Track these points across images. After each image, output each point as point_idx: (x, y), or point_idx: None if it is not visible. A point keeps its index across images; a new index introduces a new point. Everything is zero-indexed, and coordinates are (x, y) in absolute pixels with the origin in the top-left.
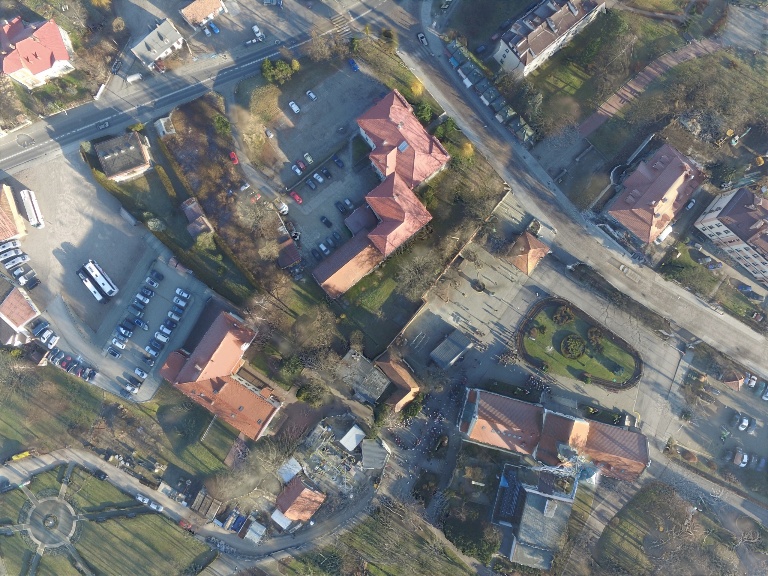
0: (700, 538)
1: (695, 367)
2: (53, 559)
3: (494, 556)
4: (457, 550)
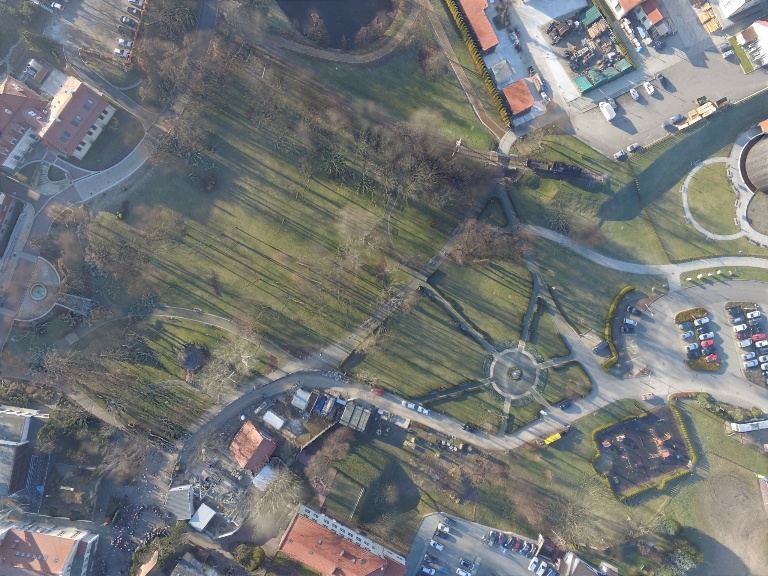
0: None
1: None
2: (508, 338)
3: (54, 406)
4: (93, 407)
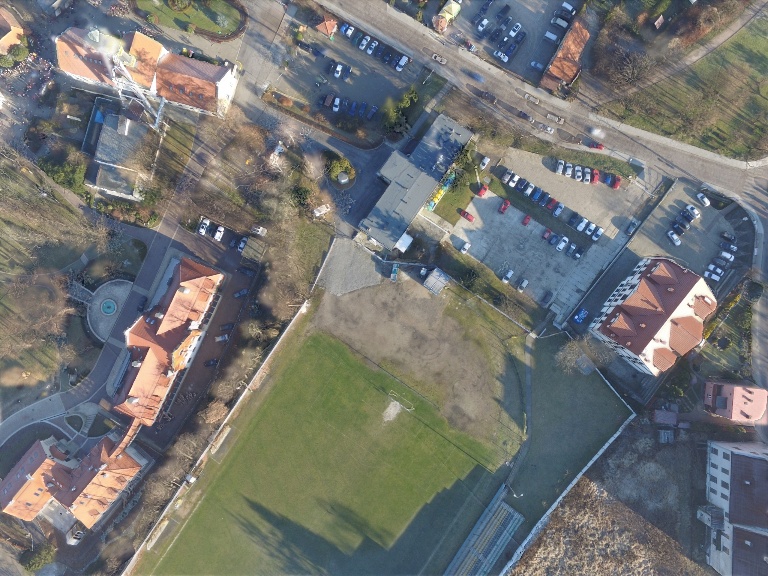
0: (287, 173)
1: (297, 20)
2: None
3: (97, 196)
4: (64, 192)
